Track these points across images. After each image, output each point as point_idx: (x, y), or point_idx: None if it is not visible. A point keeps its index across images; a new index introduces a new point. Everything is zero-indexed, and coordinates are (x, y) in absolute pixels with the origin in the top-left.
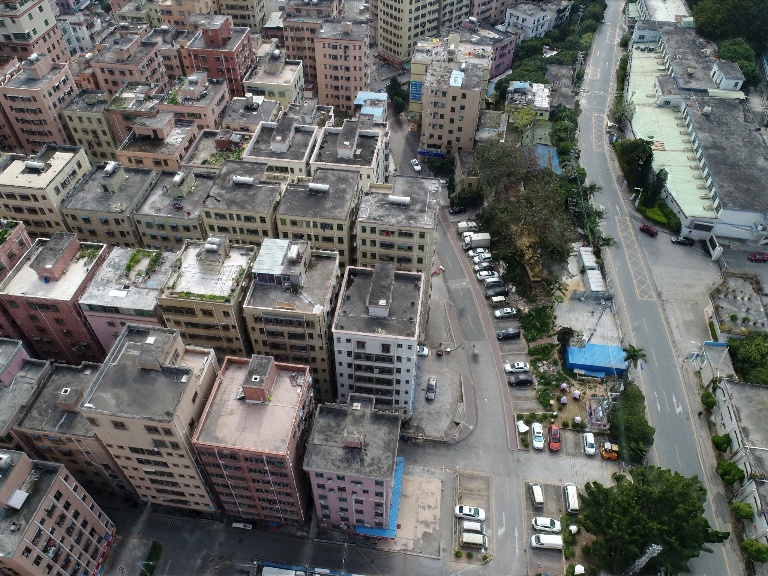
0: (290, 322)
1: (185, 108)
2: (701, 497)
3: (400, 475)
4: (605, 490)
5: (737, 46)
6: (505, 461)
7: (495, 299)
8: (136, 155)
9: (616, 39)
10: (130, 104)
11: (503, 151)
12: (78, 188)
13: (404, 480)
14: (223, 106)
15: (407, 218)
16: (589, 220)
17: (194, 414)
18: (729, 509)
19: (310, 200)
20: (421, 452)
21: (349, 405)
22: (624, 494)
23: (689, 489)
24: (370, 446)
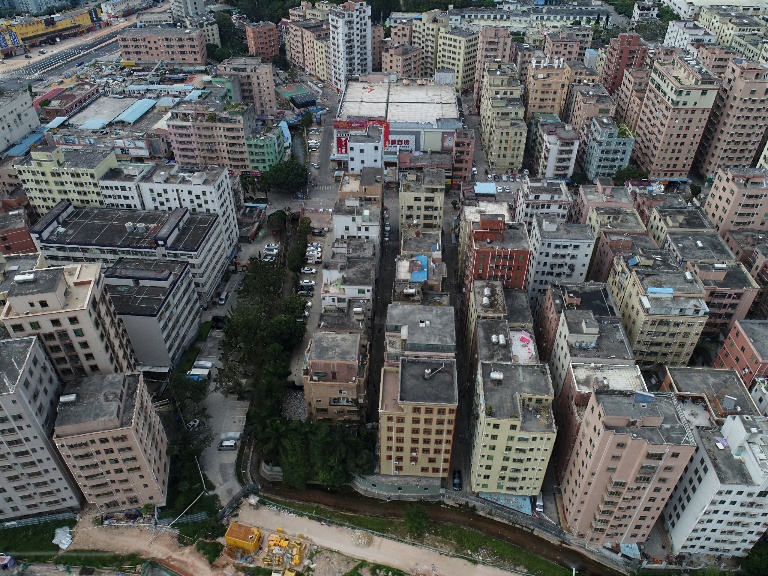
0: None
1: None
2: None
3: None
4: None
5: (486, 0)
6: None
7: None
8: None
9: None
10: None
11: None
12: None
13: None
14: None
15: None
16: None
17: None
18: None
19: None
20: None
21: None
22: None
23: None
24: None
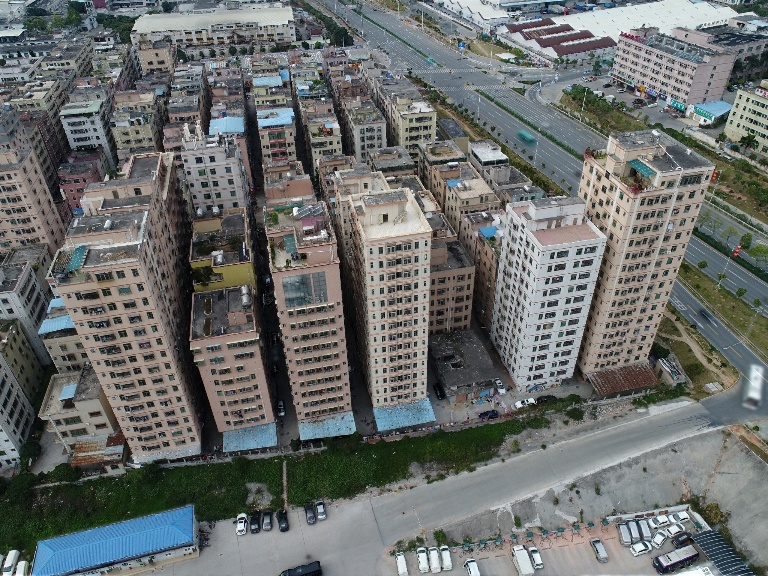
0: None
1: None
2: None
3: None
4: None
5: None
6: None
7: None
8: None
9: None
10: None
11: None
12: None
13: None
14: None
15: None
16: None
17: None
18: None
19: None
20: None
21: None
22: None
23: None
24: None
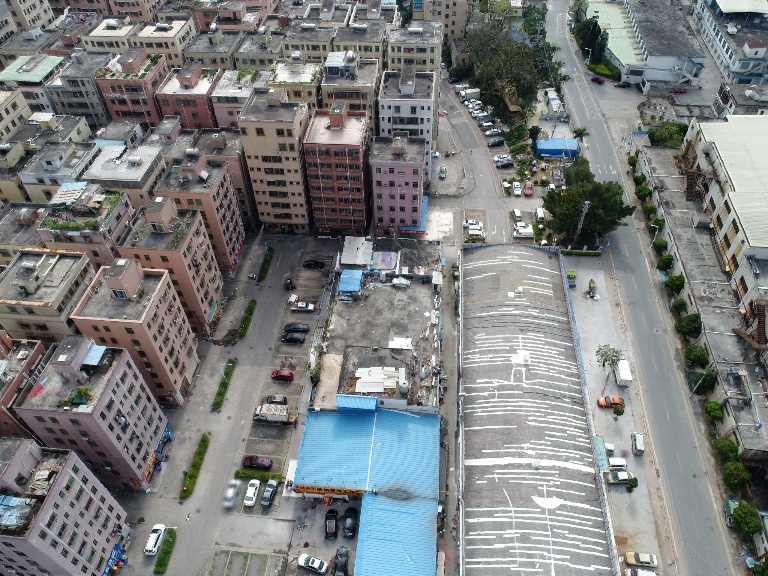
0: (351, 95)
1: (251, 2)
2: (620, 192)
3: (426, 204)
4: (558, 192)
5: None
6: (495, 202)
7: (485, 124)
8: (224, 28)
9: None
10: (207, 5)
11: (486, 26)
12: (191, 43)
13: (428, 213)
14: (276, 5)
15: (422, 40)
16: (552, 73)
17: (301, 134)
18: (644, 216)
19: (355, 35)
20: (438, 201)
21: (393, 137)
22: (571, 194)
23: (611, 185)
24: (408, 153)
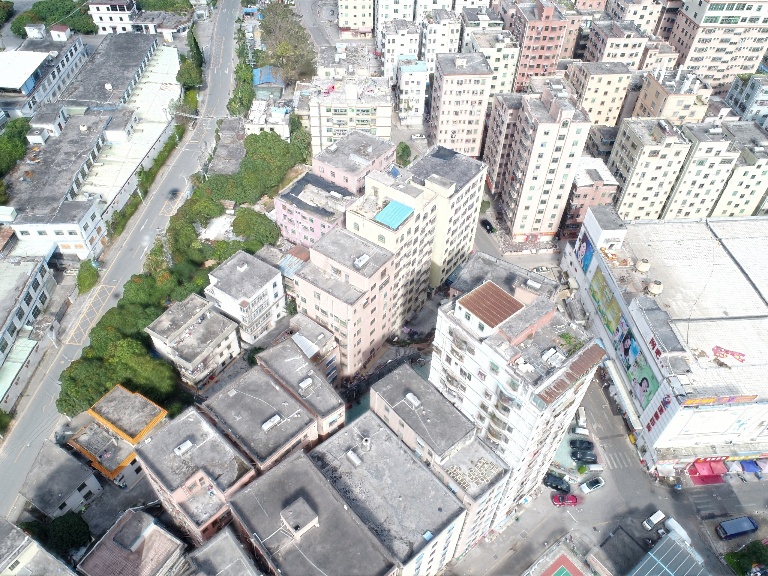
0: None
1: None
2: None
3: None
4: None
5: None
6: None
7: None
8: None
9: (92, 299)
10: None
11: None
12: None
13: None
14: None
15: None
16: None
17: None
18: None
19: None
20: None
21: None
22: None
23: None
24: None
